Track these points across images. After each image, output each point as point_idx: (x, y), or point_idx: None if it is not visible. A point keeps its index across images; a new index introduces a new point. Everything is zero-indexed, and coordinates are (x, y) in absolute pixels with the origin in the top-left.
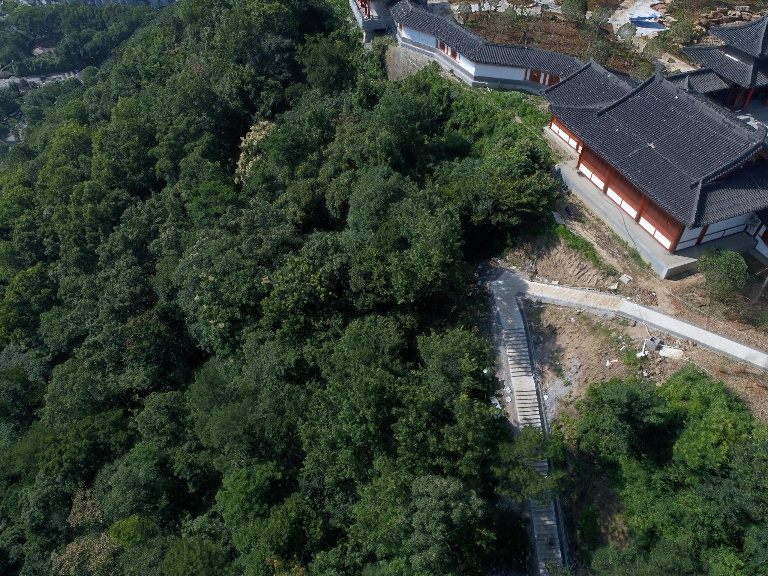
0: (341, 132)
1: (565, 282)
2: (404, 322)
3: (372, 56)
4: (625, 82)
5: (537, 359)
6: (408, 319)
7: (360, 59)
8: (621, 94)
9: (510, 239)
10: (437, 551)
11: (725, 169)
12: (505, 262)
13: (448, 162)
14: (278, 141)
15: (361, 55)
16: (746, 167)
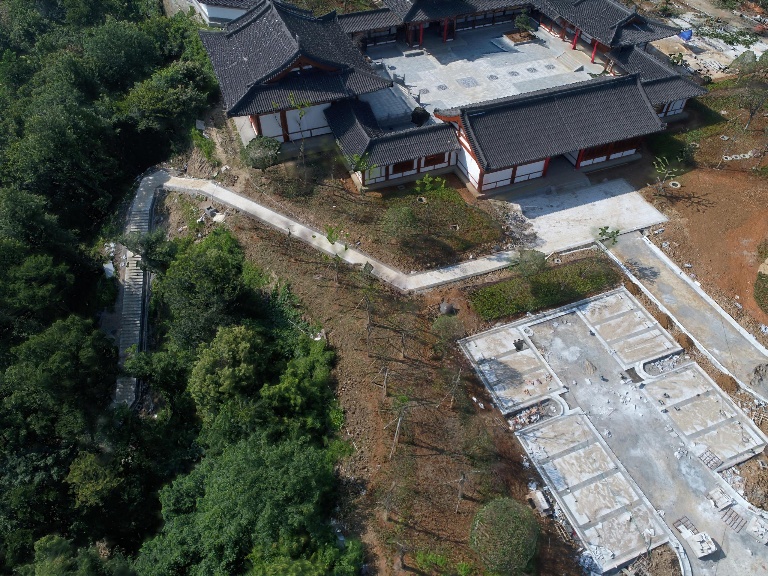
0: (51, 58)
1: (196, 176)
2: None
3: (154, 4)
4: None
5: None
6: (40, 198)
7: (146, 7)
8: None
9: (173, 145)
10: None
11: (275, 73)
12: (168, 164)
13: None
14: (2, 66)
15: (146, 3)
16: (304, 74)
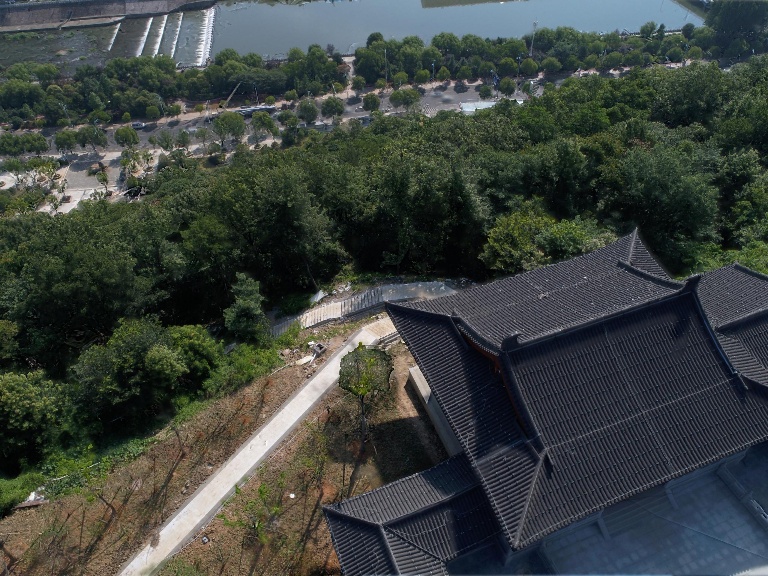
0: None
1: None
2: (370, 209)
3: None
4: None
5: (356, 318)
6: None
7: None
8: (727, 318)
9: None
10: (175, 212)
11: (474, 335)
12: None
13: (594, 222)
14: None
15: None
16: None
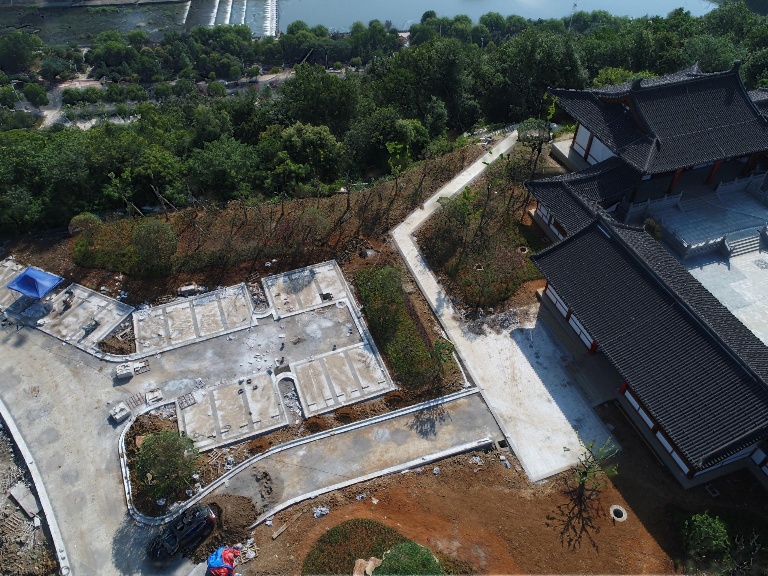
0: None
1: None
2: None
3: None
4: (767, 97)
5: None
6: None
7: None
8: None
9: None
10: None
11: (609, 95)
12: None
13: None
14: None
15: None
16: (628, 115)
